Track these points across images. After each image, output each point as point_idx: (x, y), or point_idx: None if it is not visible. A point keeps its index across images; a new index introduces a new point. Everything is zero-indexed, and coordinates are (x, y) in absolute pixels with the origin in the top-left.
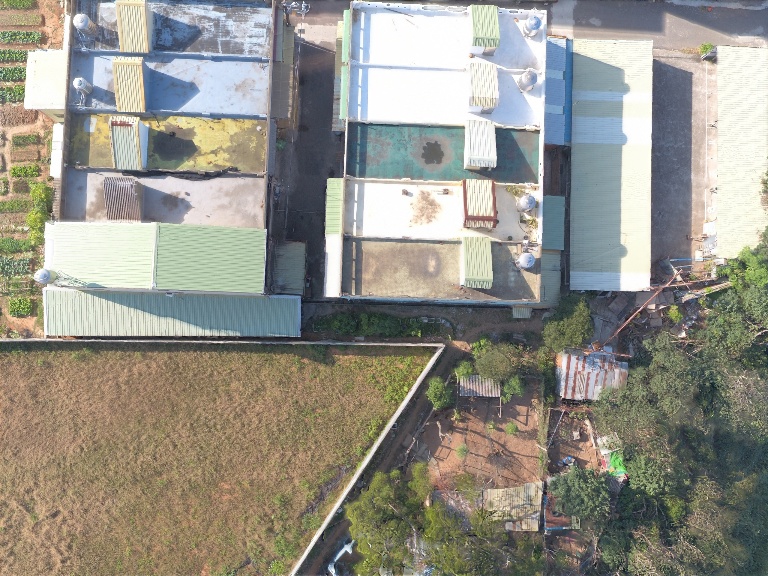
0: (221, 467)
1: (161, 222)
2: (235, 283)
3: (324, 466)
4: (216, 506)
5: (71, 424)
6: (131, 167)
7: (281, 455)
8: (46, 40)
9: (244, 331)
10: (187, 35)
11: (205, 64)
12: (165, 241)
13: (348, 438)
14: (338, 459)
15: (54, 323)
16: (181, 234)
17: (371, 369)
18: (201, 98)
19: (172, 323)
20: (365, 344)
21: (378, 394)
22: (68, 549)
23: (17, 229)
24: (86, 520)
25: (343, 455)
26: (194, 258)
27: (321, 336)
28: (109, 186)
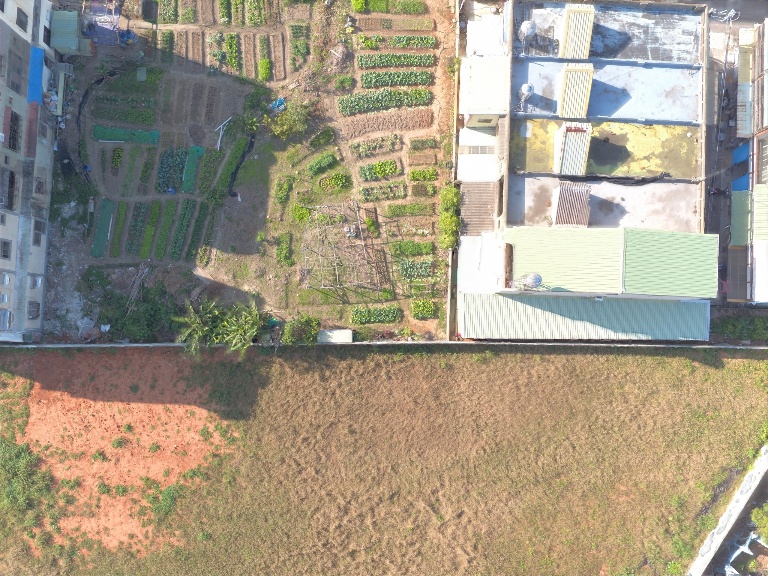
0: (618, 469)
1: (598, 227)
2: (693, 288)
3: (718, 468)
4: (614, 507)
5: (474, 426)
6: (575, 172)
7: (677, 457)
8: (438, 45)
9: (655, 335)
10: (618, 42)
11: (636, 71)
12: (632, 246)
13: (740, 441)
14: (730, 461)
15: (471, 326)
16: (645, 239)
17: (759, 372)
18: (633, 104)
19: (585, 326)
20: (765, 348)
21: (767, 397)
22: (474, 549)
23: (418, 232)
24: (490, 521)
25: (736, 457)
26: (657, 263)
27: (709, 340)
28: (565, 191)
